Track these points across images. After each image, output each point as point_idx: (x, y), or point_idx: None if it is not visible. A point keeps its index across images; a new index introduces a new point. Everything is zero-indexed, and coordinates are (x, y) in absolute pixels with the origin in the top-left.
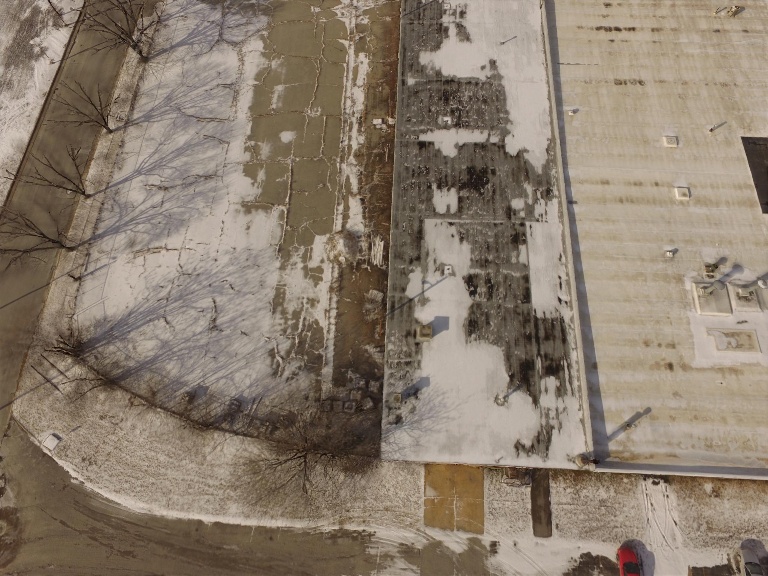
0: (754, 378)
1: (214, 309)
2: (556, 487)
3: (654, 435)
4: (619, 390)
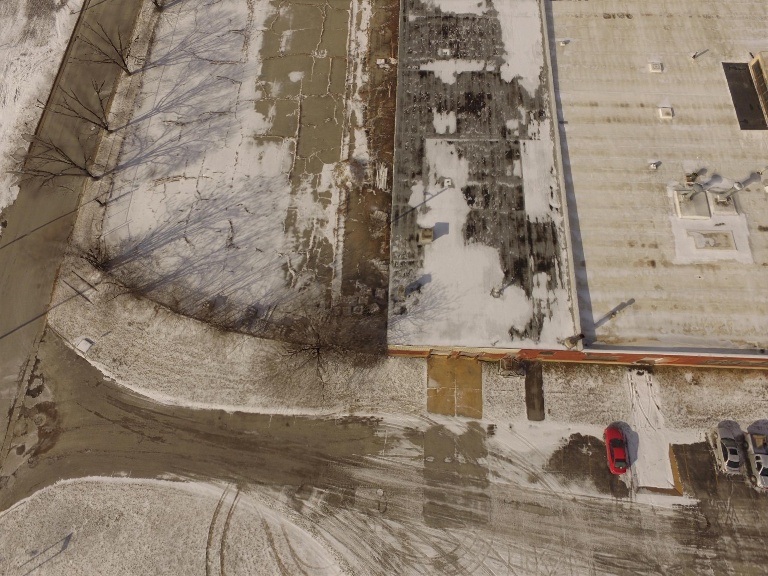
0: (730, 272)
1: (231, 229)
2: (548, 378)
3: (637, 322)
4: (605, 284)
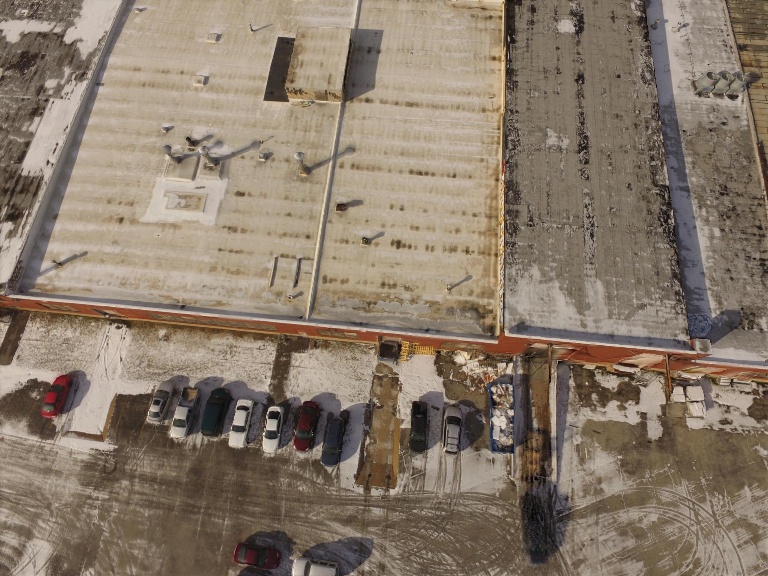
0: (188, 232)
1: None
2: (31, 326)
3: (80, 273)
4: (67, 237)
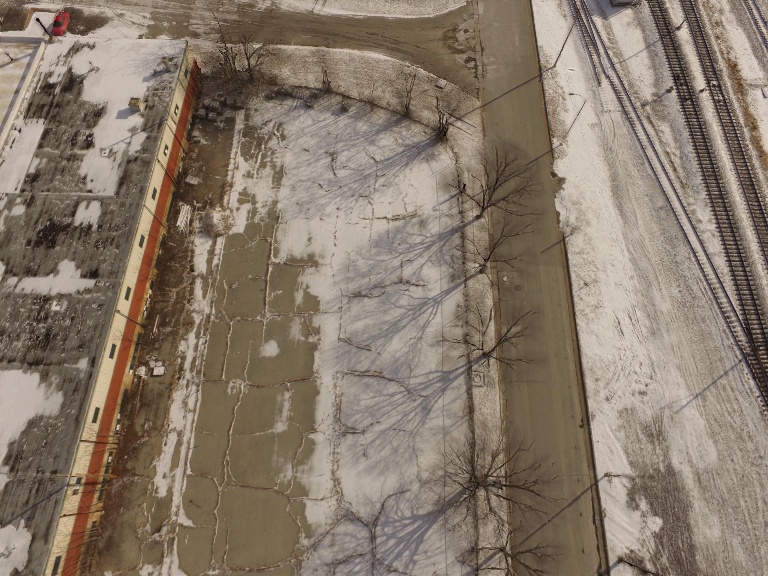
0: None
1: (334, 168)
2: None
3: None
4: (7, 79)
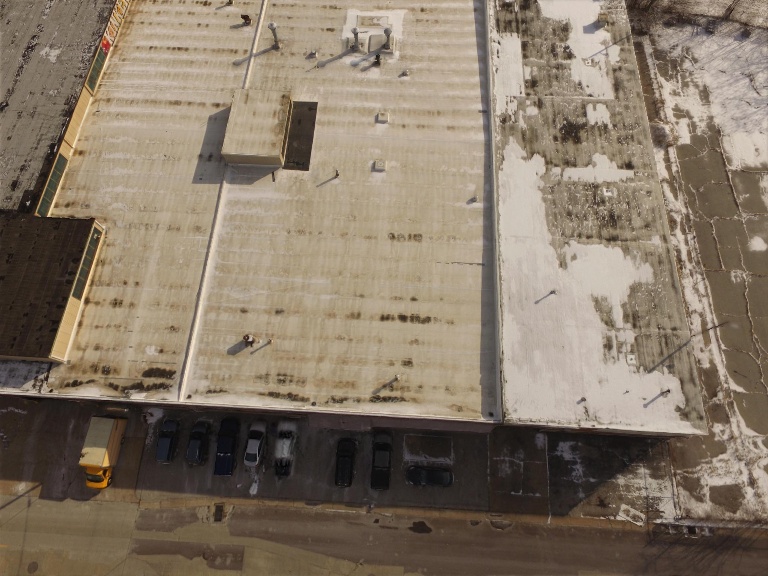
0: (367, 4)
1: (755, 88)
2: None
3: None
4: None
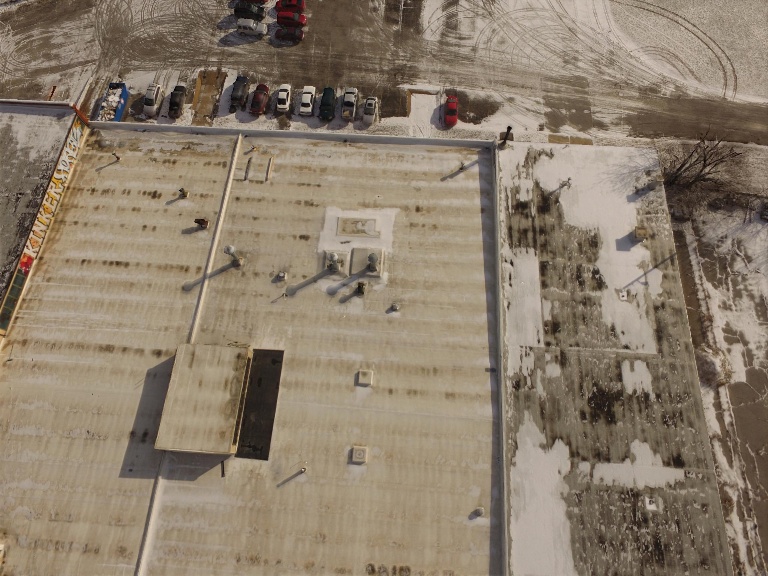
0: (351, 200)
1: None
2: None
3: (442, 164)
4: (465, 193)
